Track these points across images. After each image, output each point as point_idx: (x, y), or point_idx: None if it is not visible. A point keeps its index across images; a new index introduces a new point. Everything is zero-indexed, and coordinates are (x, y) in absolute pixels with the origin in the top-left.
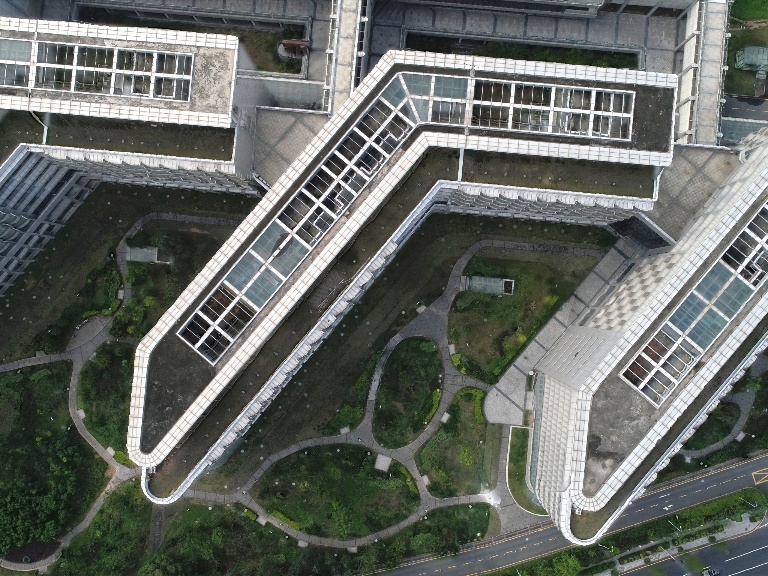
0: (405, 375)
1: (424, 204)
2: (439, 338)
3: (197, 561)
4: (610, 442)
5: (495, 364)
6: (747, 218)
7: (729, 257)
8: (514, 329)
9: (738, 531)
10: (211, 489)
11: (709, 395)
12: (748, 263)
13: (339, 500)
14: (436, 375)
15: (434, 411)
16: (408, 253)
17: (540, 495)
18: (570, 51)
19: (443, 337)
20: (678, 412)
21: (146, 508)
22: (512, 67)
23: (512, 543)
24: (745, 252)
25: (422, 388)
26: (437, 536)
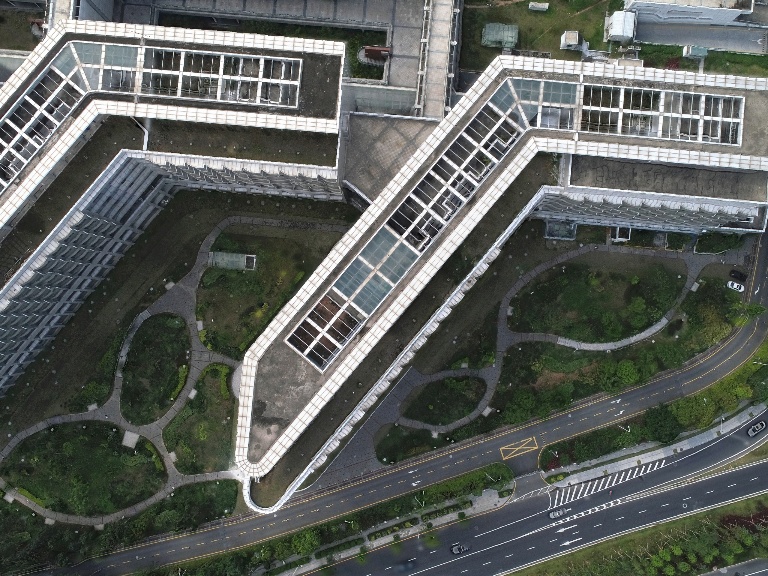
0: (151, 351)
1: (111, 173)
2: (187, 314)
3: None
4: (275, 408)
5: (241, 340)
6: (412, 184)
7: (395, 223)
8: (260, 305)
9: (487, 507)
10: None
11: (390, 362)
12: (413, 229)
13: (79, 476)
14: (183, 351)
15: (180, 387)
16: (156, 230)
17: None
18: (321, 29)
19: (191, 313)
20: (342, 377)
21: None
22: (181, 35)
23: (260, 520)
24: (411, 218)
25: (169, 364)
26: (180, 512)
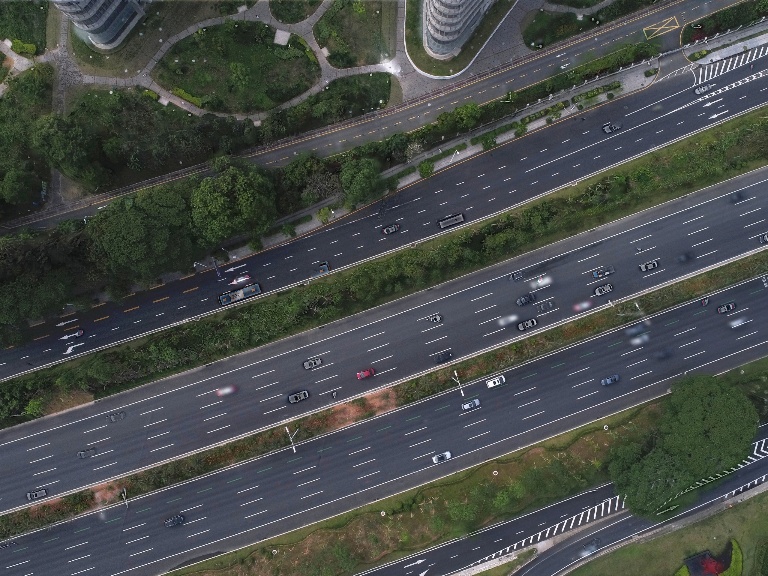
0: None
1: None
2: None
3: (96, 124)
4: None
5: None
6: None
7: None
8: None
9: (635, 87)
10: (111, 74)
11: None
12: None
13: (237, 63)
14: None
15: None
16: None
17: (428, 11)
18: None
19: None
20: None
21: (45, 91)
22: None
23: (415, 109)
24: None
25: None
26: None
